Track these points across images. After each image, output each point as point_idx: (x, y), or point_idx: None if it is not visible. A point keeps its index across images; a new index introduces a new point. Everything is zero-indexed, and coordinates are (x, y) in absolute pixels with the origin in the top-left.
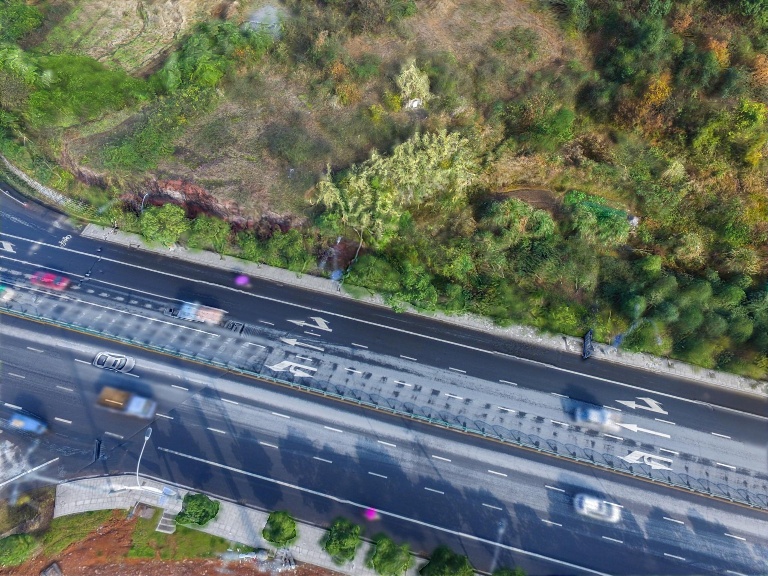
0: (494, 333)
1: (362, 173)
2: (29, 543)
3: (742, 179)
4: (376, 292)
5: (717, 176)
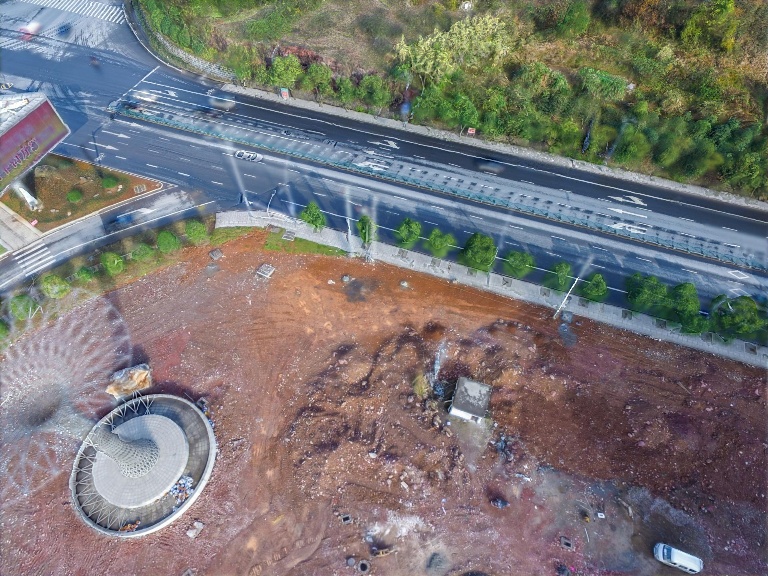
0: (519, 155)
1: None
2: (205, 231)
3: (718, 59)
4: (432, 128)
5: (698, 56)
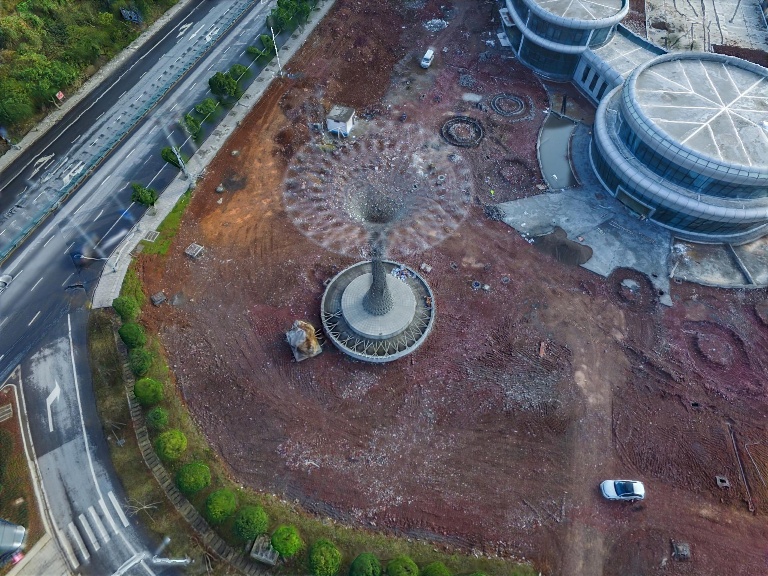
0: (107, 76)
1: None
2: None
3: None
4: (36, 127)
5: None
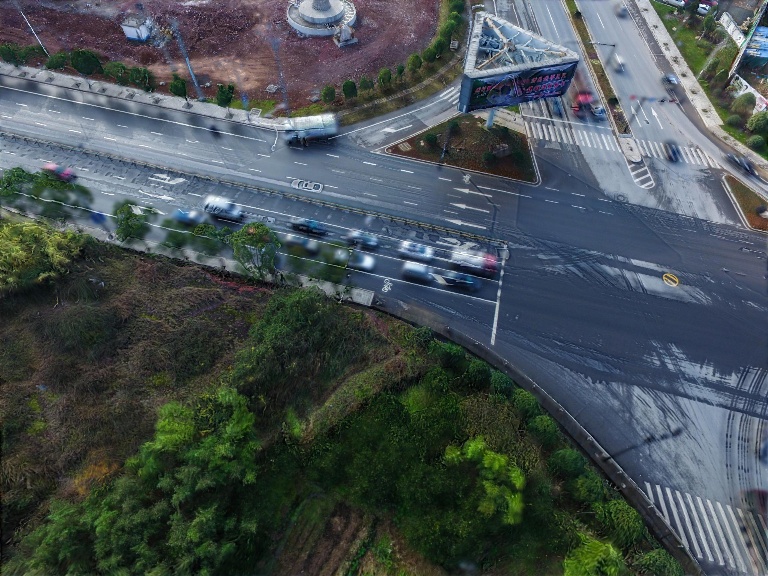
0: None
1: (4, 272)
2: None
3: None
4: None
5: None
